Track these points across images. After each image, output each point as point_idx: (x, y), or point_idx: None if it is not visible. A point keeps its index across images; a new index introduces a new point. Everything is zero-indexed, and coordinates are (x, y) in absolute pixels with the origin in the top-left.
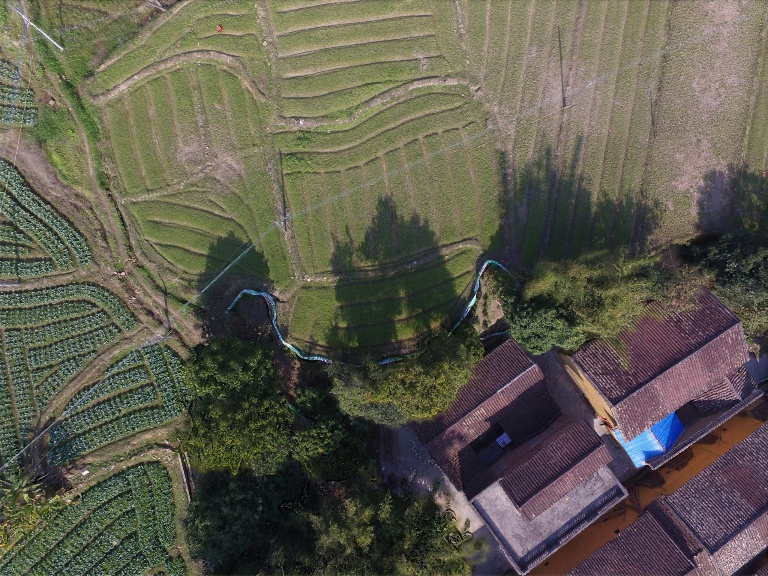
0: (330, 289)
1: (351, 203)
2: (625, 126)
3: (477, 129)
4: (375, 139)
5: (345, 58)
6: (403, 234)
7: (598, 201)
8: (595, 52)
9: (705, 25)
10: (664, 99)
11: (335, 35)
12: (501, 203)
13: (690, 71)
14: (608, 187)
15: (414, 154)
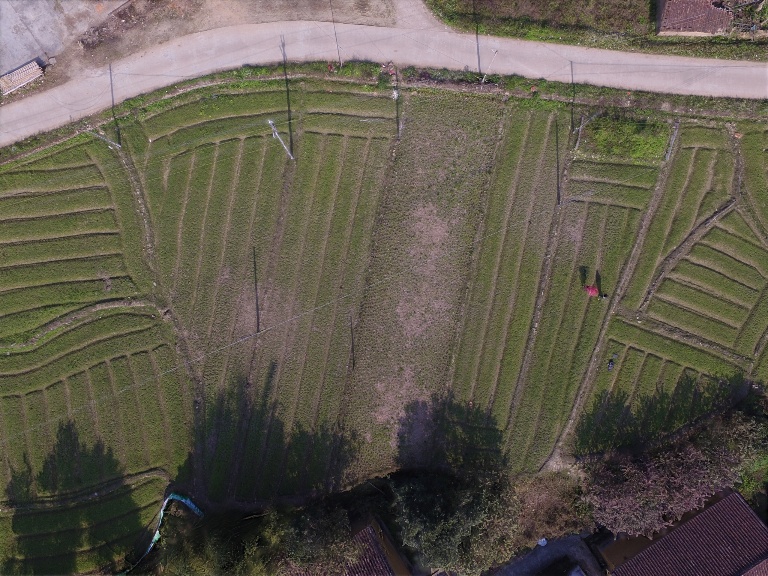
0: (6, 520)
1: (30, 430)
2: (323, 353)
3: (167, 352)
4: (57, 362)
5: (23, 279)
6: (84, 464)
7: (292, 432)
8: (293, 274)
9: (412, 246)
10: (365, 324)
11: (13, 254)
12: (191, 431)
13: (394, 295)
14: (302, 418)
15: (99, 378)
